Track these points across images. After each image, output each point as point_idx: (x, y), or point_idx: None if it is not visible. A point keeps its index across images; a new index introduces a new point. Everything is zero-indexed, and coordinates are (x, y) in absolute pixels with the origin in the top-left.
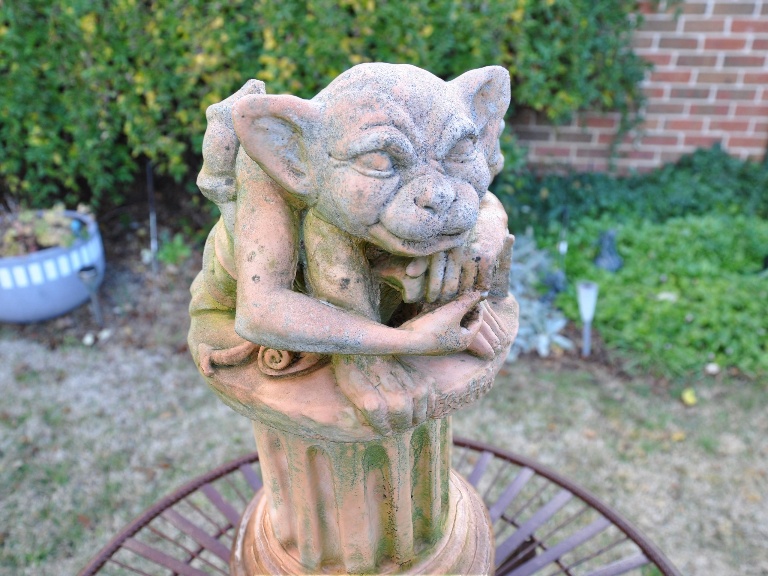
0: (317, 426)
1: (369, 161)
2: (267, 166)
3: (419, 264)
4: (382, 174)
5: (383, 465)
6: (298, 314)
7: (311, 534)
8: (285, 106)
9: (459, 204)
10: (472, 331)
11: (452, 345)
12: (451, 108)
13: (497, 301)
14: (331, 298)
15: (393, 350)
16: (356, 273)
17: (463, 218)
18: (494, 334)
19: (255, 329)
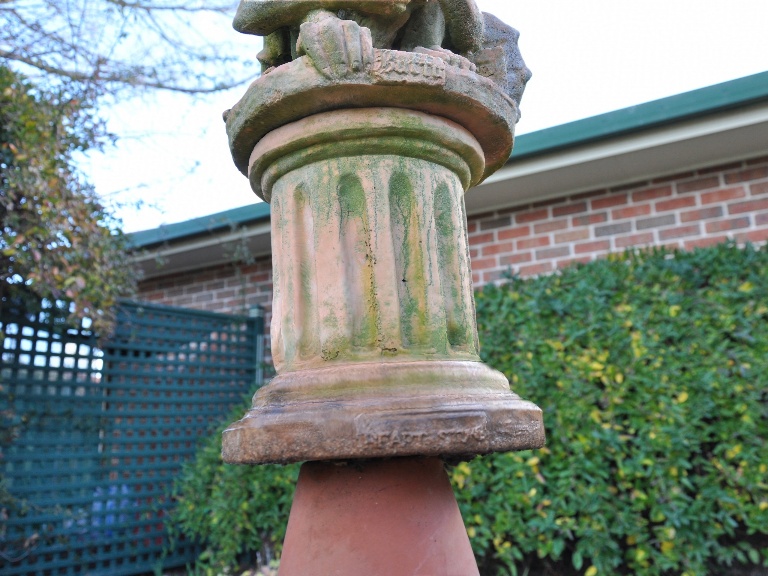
0: (274, 80)
1: None
2: None
3: None
4: None
5: (363, 211)
6: None
7: (292, 303)
8: None
9: None
10: None
11: None
12: None
13: None
14: None
15: None
16: None
17: None
18: None
19: (240, 7)
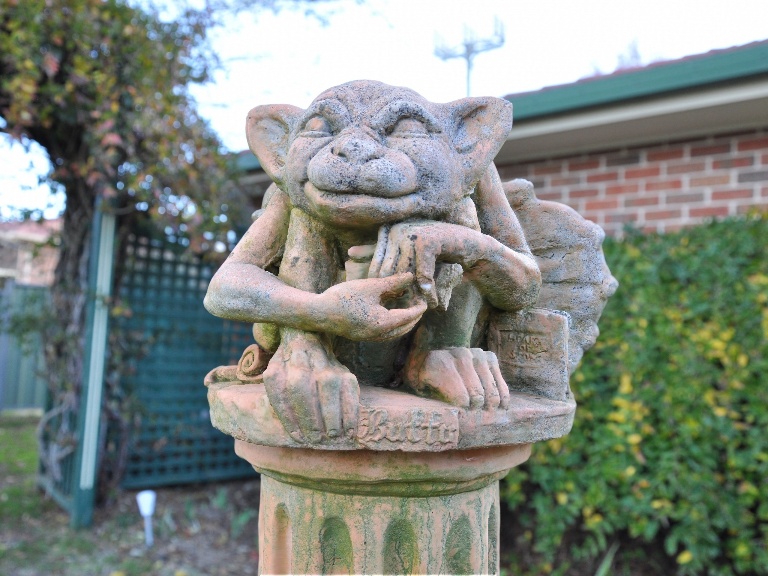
0: (239, 414)
1: (309, 125)
2: (260, 157)
3: (364, 247)
4: (314, 133)
5: (351, 563)
6: (235, 270)
7: None
8: (280, 109)
9: (378, 159)
10: (392, 312)
11: (358, 314)
12: (404, 96)
13: (543, 398)
14: (283, 277)
15: (298, 309)
16: (308, 254)
17: (376, 169)
18: (479, 383)
19: None
